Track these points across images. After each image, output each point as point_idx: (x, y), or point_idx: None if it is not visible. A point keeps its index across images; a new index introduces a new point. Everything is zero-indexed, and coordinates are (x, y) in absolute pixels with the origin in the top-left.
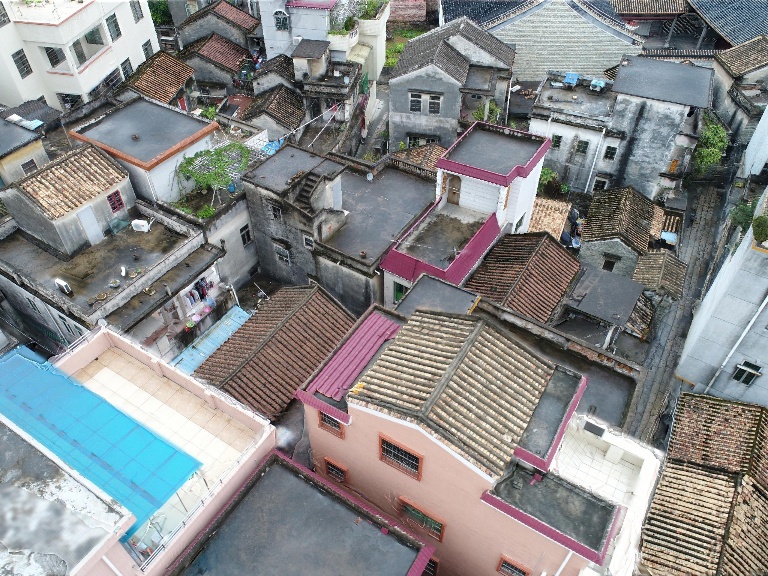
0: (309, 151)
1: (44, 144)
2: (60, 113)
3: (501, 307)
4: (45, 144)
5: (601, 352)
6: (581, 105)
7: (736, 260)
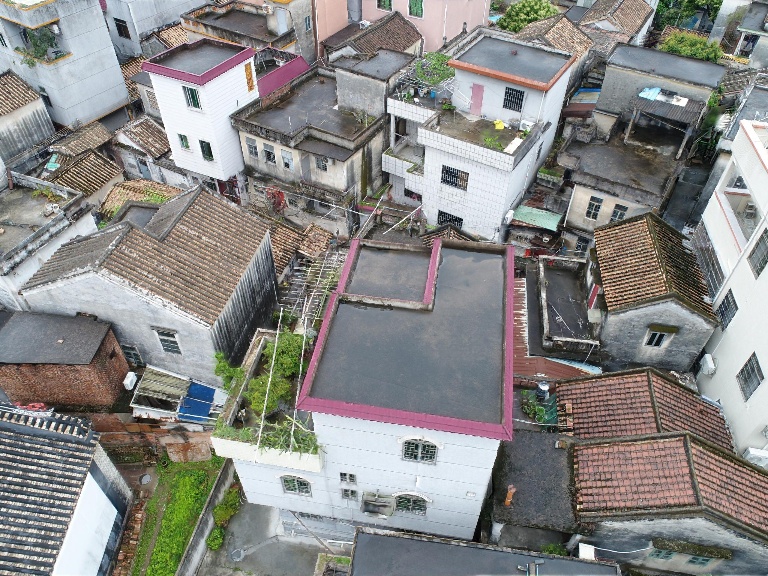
0: (363, 72)
1: (666, 152)
2: (637, 106)
3: (241, 32)
4: (665, 152)
5: (198, 19)
6: (6, 219)
7: (84, 24)
